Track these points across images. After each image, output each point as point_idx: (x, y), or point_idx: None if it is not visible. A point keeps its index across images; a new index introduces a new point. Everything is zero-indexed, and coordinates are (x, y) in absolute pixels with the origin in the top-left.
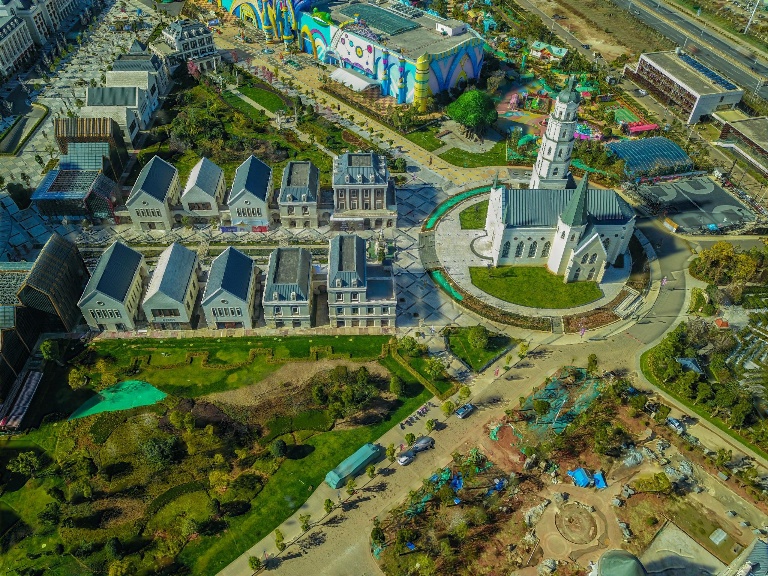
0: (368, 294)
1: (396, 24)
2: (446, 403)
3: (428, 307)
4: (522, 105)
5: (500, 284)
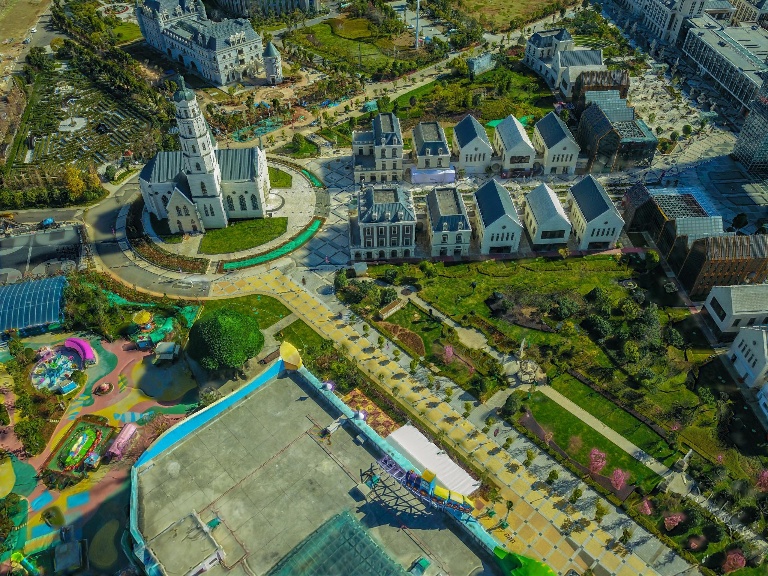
0: (372, 136)
1: (330, 553)
2: (326, 112)
3: None
4: (110, 443)
5: (270, 177)
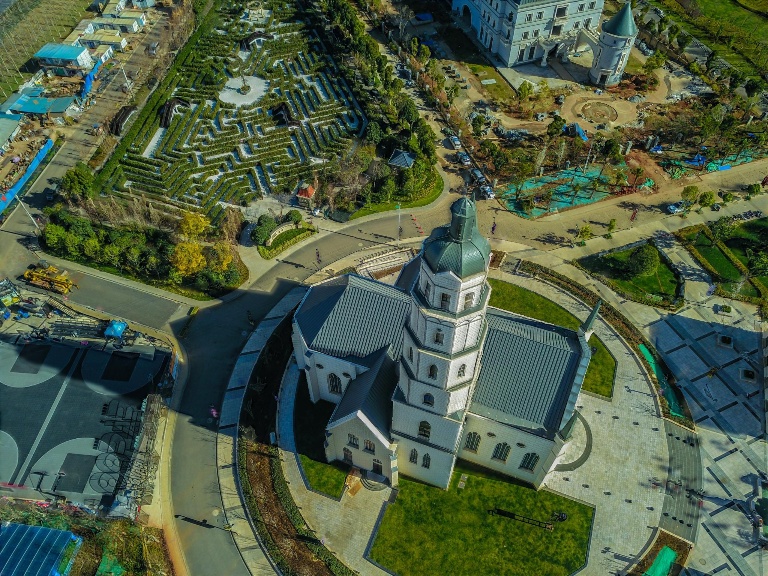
0: None
1: None
2: None
3: (701, 352)
4: None
5: None
